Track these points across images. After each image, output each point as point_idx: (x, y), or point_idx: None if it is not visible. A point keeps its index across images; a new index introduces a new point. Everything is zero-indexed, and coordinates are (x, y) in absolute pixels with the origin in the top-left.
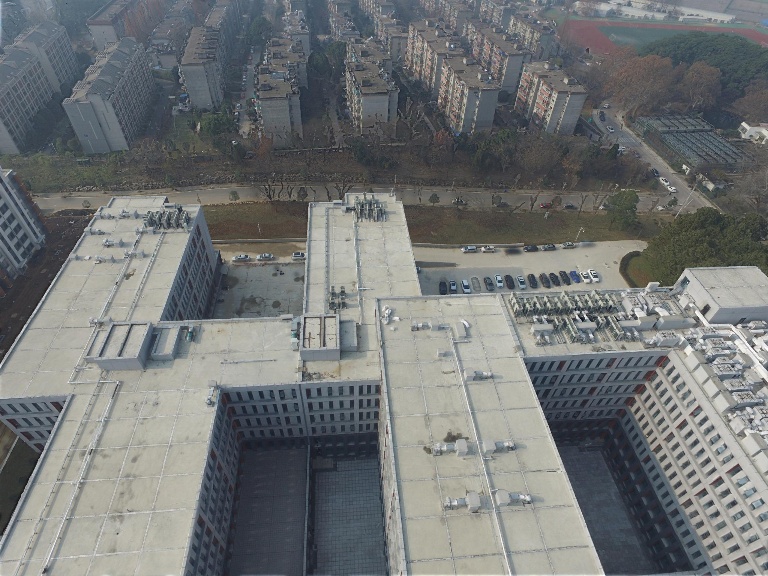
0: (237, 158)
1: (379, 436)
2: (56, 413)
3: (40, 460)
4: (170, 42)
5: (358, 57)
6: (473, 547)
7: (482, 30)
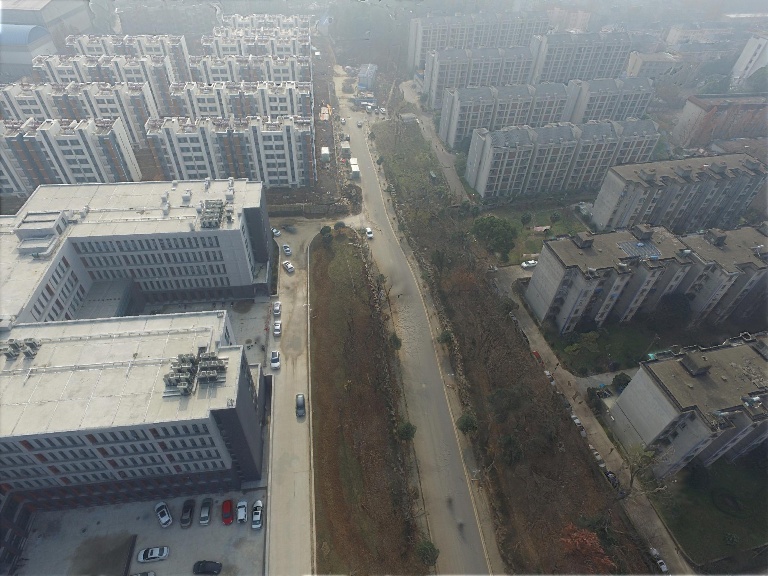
0: None
1: None
2: None
3: None
4: None
5: None
6: None
7: None
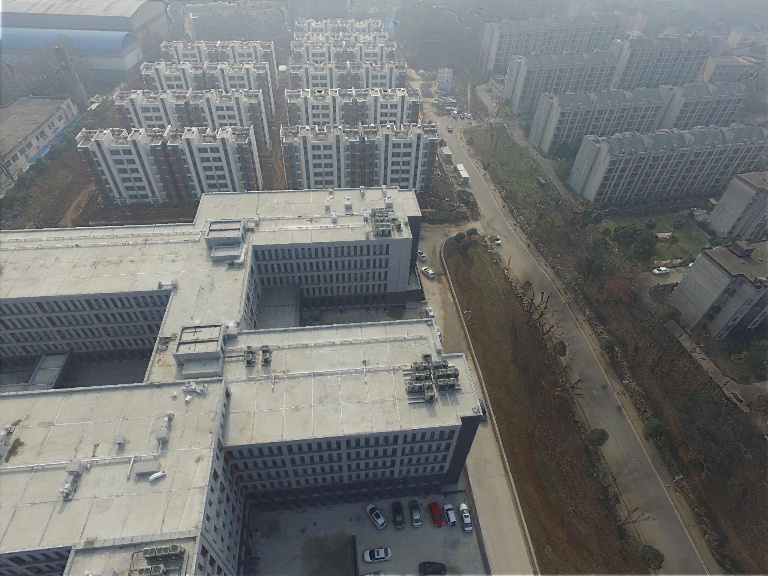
0: None
1: None
2: None
3: None
4: None
5: None
6: None
7: None
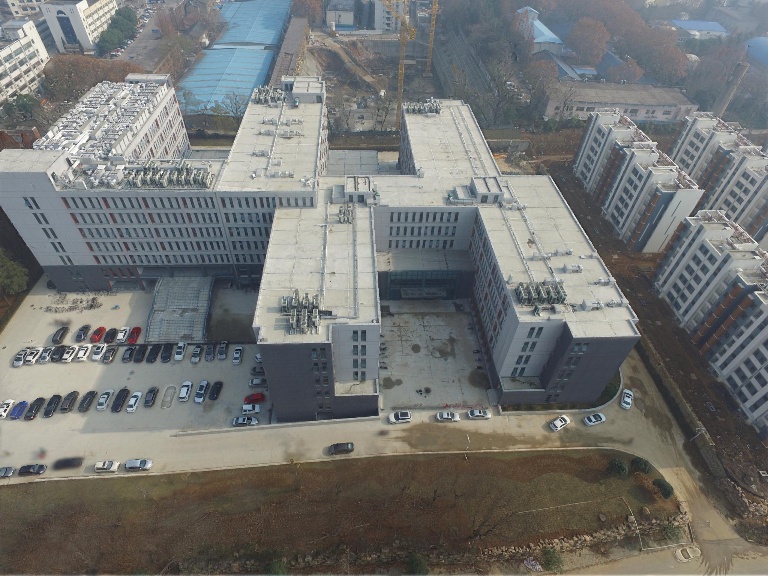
0: None
1: None
2: None
3: None
4: None
5: None
6: (294, 116)
7: None
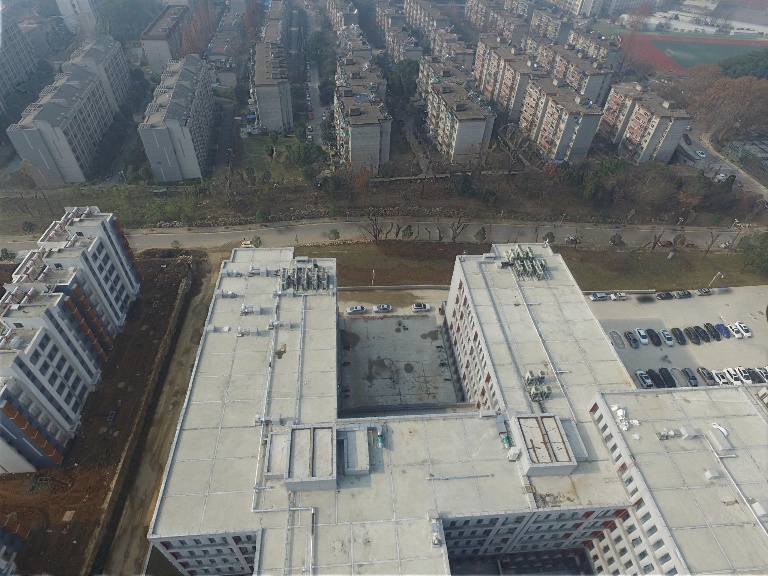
0: (333, 192)
1: (603, 561)
2: (232, 545)
3: None
4: (229, 58)
5: (439, 77)
6: None
7: (553, 47)
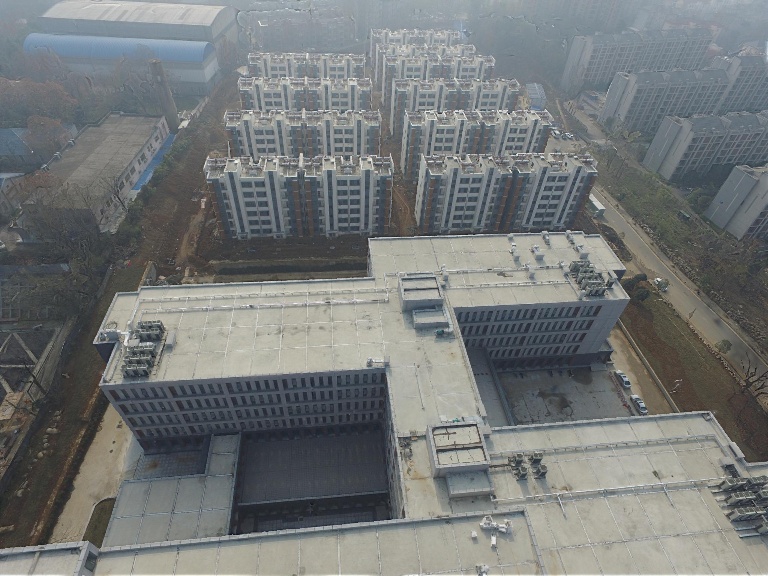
0: None
1: None
2: None
3: (323, 280)
4: None
5: None
6: None
7: None
